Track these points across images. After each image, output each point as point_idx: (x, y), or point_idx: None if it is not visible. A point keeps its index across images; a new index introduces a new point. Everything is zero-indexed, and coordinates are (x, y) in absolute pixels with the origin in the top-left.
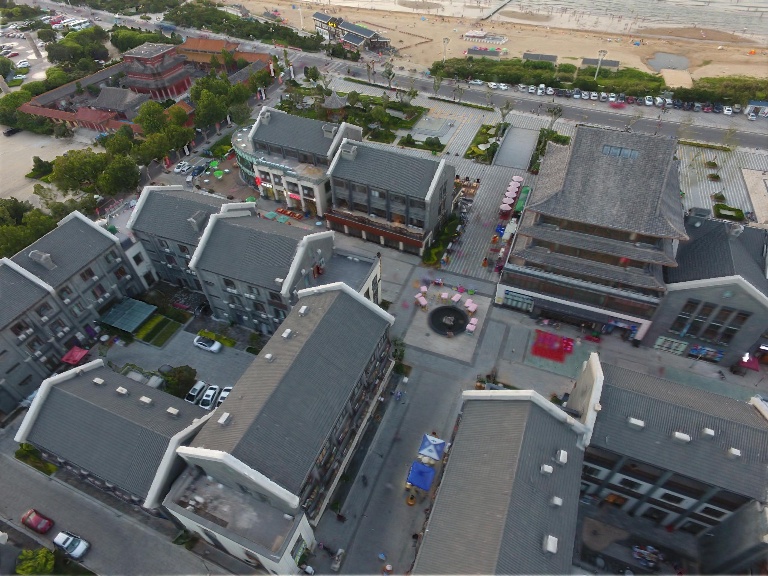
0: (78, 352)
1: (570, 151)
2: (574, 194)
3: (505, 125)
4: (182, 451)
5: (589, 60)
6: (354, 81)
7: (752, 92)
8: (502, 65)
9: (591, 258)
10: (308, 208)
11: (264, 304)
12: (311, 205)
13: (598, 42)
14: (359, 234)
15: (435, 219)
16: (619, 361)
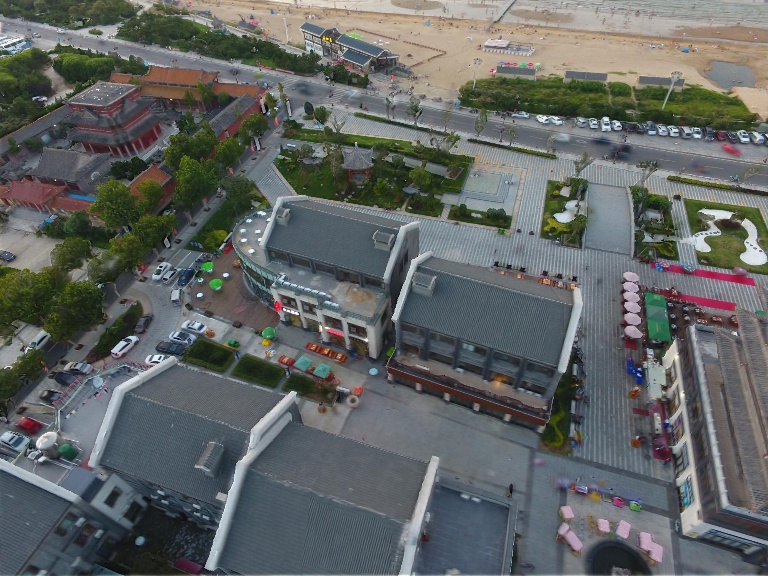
0: None
1: None
2: None
3: (584, 185)
4: None
5: (647, 78)
6: (368, 118)
7: None
8: (546, 89)
9: None
10: (354, 345)
11: None
12: (360, 343)
13: (640, 49)
14: (438, 393)
15: None
16: None
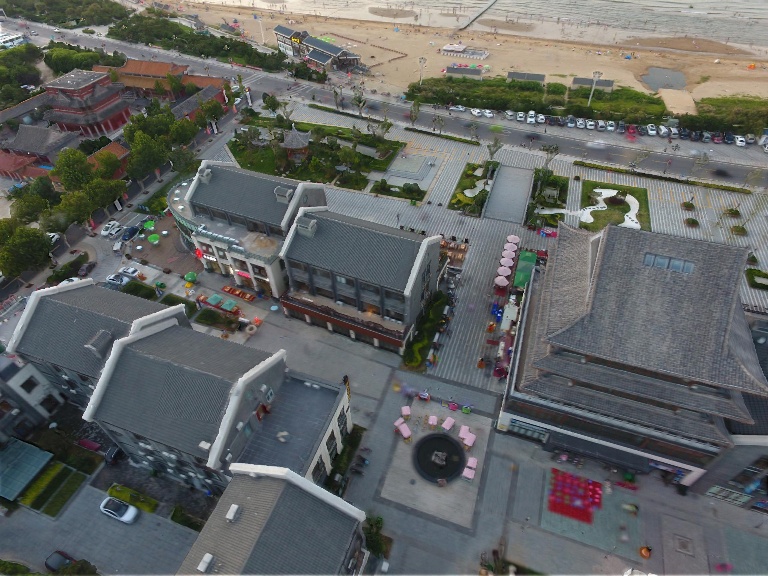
0: None
1: (599, 259)
2: (607, 320)
3: (494, 166)
4: None
5: (580, 79)
6: (320, 108)
7: (766, 120)
8: (485, 87)
9: (628, 396)
10: (261, 287)
11: (190, 464)
12: (264, 284)
13: (586, 56)
14: (324, 324)
15: (417, 308)
16: (664, 519)
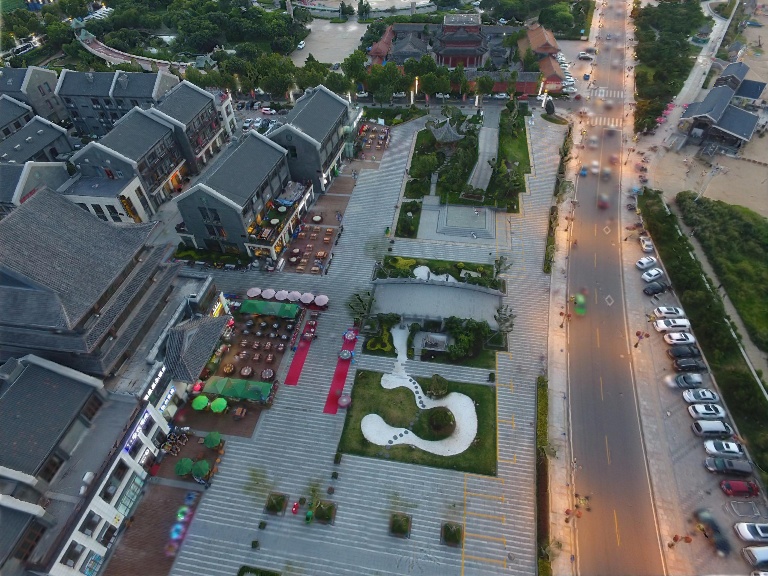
0: None
1: None
2: None
3: (471, 278)
4: None
5: None
6: None
7: None
8: None
9: None
10: None
11: None
12: None
13: None
14: None
15: (204, 232)
16: None
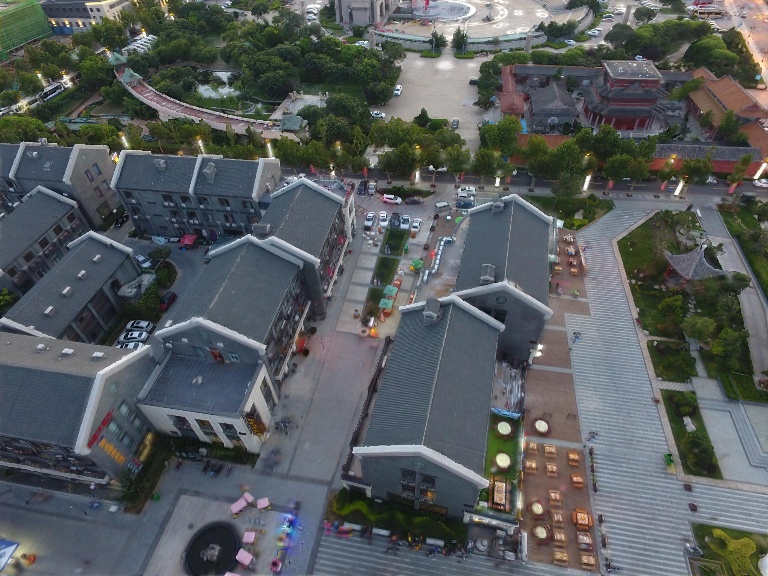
0: (188, 239)
1: None
2: None
3: None
4: None
5: None
6: None
7: None
8: None
9: None
10: None
11: None
12: None
13: None
14: None
15: (392, 486)
16: None
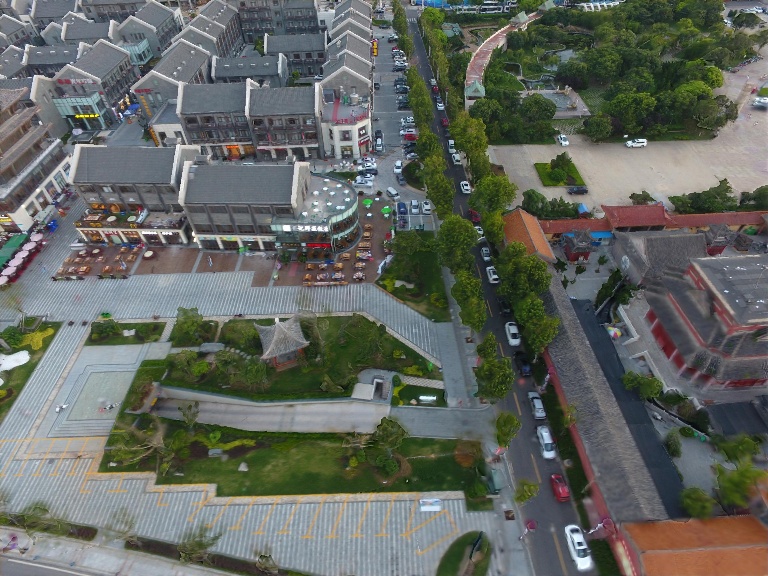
0: None
1: None
2: None
3: None
4: (205, 50)
5: None
6: None
7: None
8: None
9: None
10: None
11: None
12: None
13: None
14: None
15: None
16: None
